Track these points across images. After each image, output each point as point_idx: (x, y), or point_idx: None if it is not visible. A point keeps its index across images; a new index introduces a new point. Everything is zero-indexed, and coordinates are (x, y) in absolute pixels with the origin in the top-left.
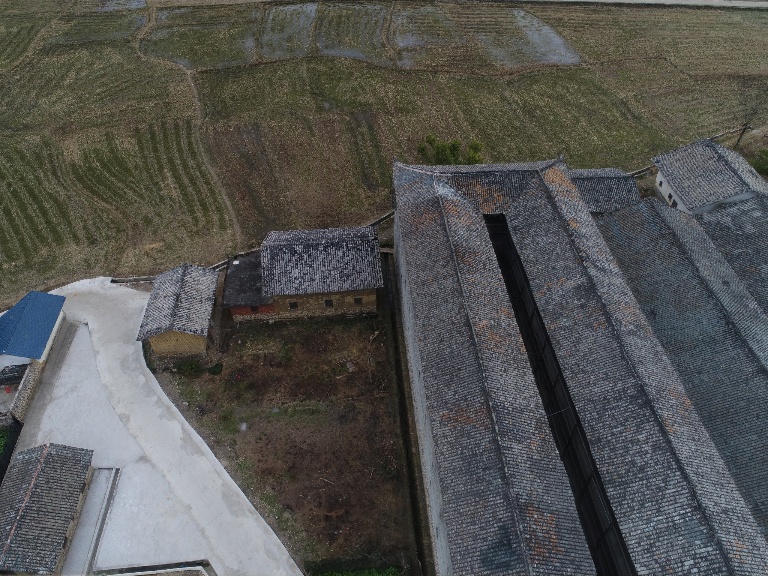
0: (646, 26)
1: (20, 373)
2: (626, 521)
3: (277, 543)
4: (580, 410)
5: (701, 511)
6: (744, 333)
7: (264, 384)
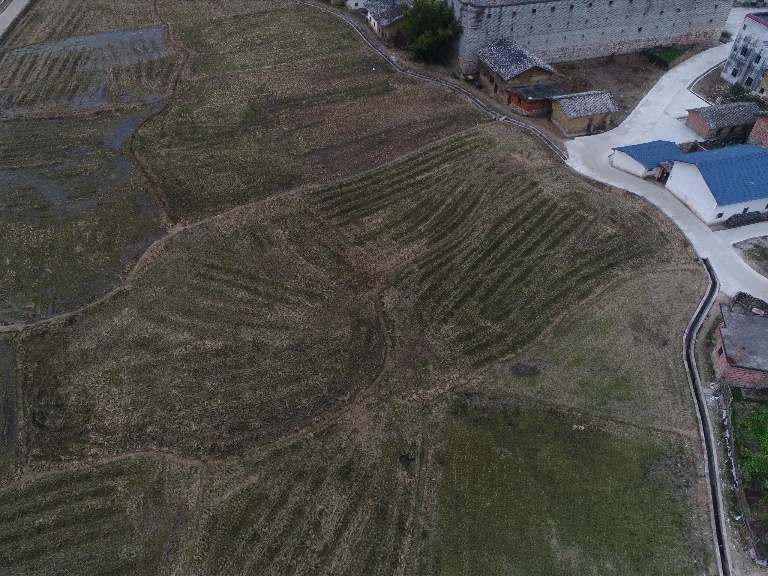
0: (83, 3)
1: None
2: None
3: None
4: None
5: None
6: None
7: None
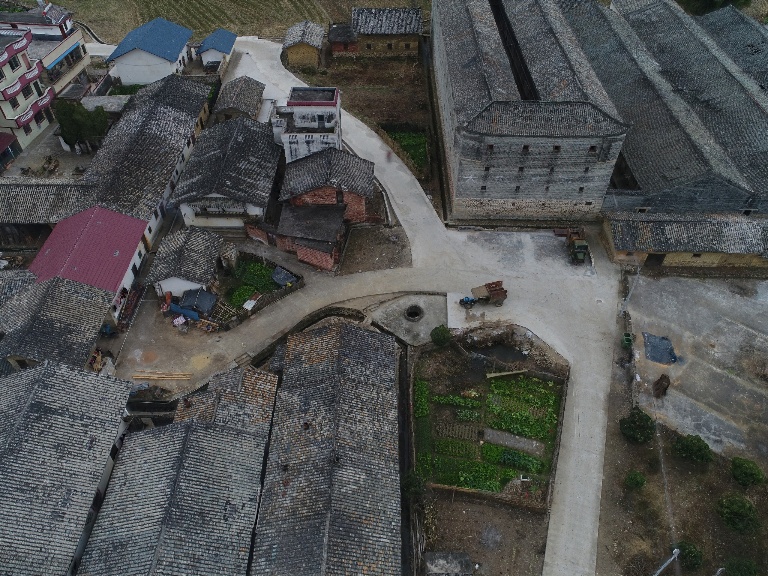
0: None
1: (217, 64)
2: (532, 67)
3: (362, 124)
4: (520, 42)
5: (564, 55)
6: (629, 49)
7: (352, 79)
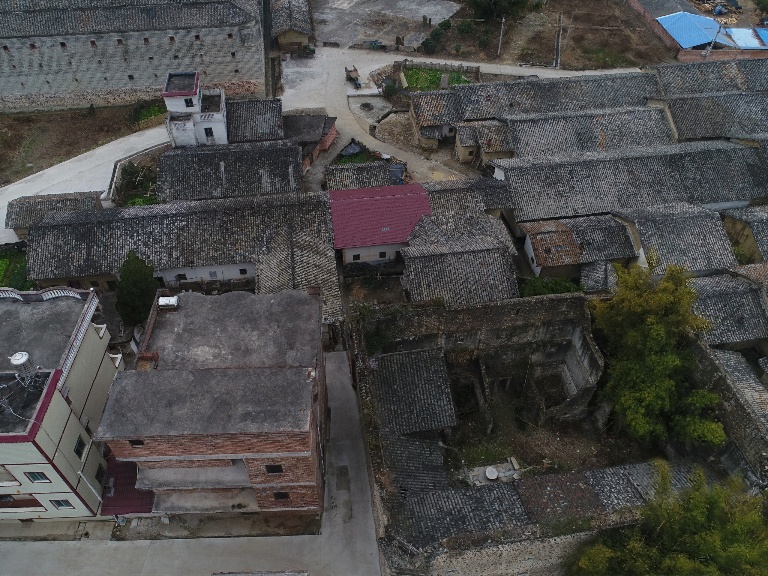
0: None
1: None
2: (148, 2)
3: (115, 141)
4: (95, 5)
5: None
6: None
7: None
